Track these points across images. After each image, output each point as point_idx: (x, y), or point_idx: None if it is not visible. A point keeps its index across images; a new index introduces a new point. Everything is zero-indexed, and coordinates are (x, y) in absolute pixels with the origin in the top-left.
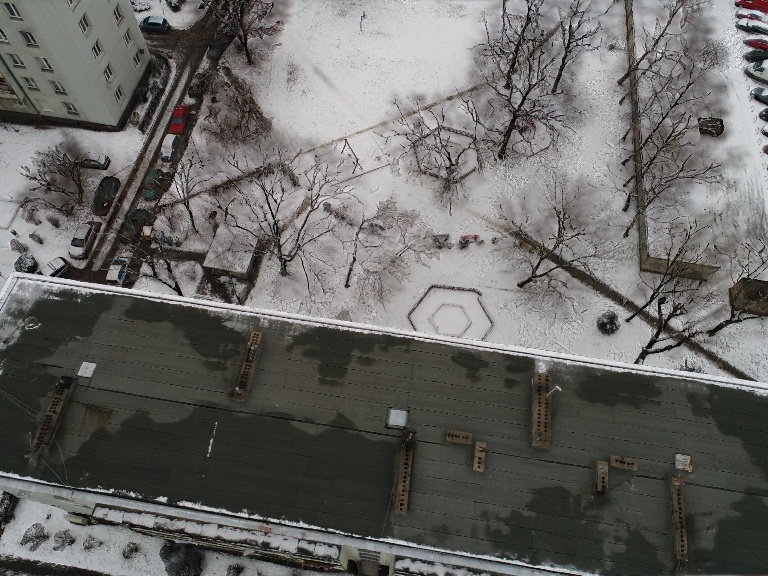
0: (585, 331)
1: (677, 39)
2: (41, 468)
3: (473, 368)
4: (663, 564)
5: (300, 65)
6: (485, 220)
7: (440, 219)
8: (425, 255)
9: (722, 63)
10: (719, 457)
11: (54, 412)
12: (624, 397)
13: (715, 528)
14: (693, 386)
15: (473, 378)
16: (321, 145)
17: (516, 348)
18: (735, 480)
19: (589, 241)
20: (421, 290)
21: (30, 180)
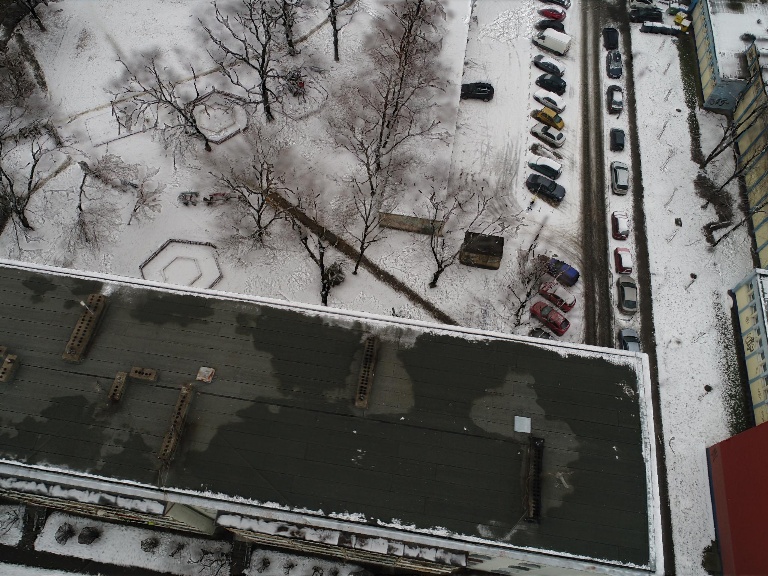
0: (311, 283)
1: (462, 8)
2: None
3: (40, 291)
4: (152, 464)
5: (93, 32)
6: (239, 179)
7: (195, 178)
8: (171, 211)
9: (512, 32)
10: (243, 370)
11: None
12: (175, 317)
13: (214, 432)
14: (247, 307)
15: (36, 300)
16: (95, 108)
17: (92, 274)
18: (249, 390)
19: (336, 199)
20: (160, 244)
21: None
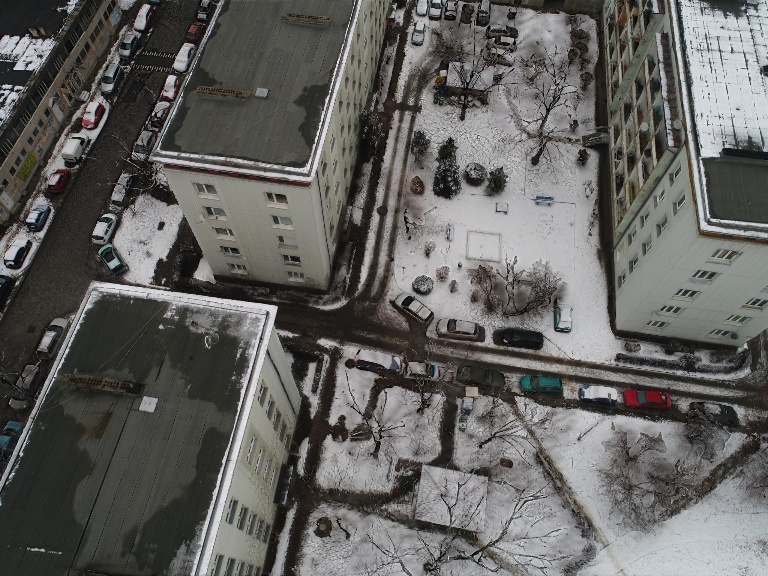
0: None
1: None
2: (61, 386)
3: None
4: None
5: None
6: None
7: None
8: None
9: None
10: None
11: (104, 386)
12: None
13: None
14: None
15: None
16: None
17: None
18: None
19: None
20: None
21: (529, 262)
